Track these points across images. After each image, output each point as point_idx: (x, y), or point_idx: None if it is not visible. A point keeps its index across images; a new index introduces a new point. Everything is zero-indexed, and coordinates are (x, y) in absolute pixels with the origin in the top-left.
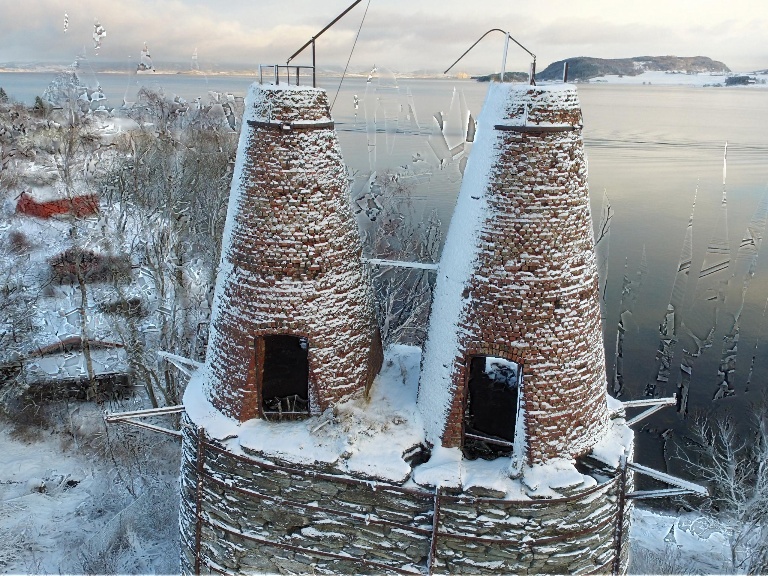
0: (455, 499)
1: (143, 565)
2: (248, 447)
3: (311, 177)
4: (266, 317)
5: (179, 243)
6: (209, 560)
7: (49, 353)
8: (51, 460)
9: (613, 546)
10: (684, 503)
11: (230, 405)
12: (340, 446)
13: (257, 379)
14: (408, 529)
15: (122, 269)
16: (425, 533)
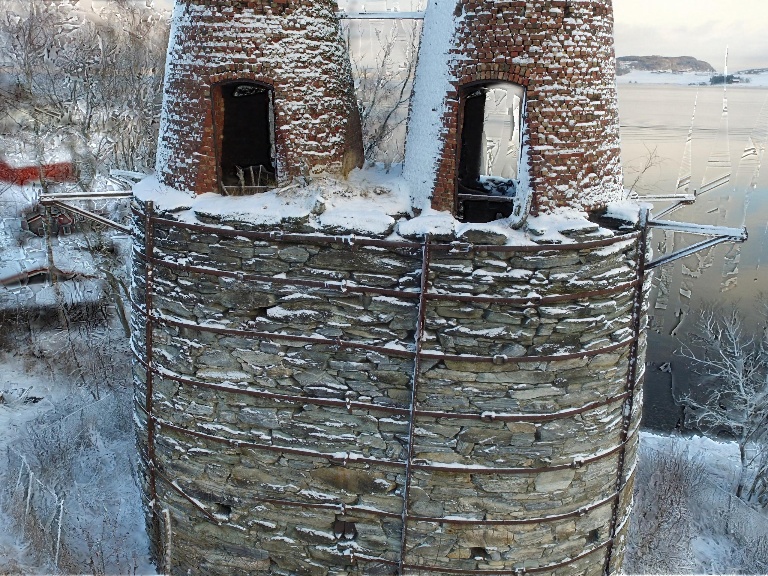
0: (447, 248)
1: (106, 461)
2: (203, 211)
3: None
4: (223, 58)
5: (151, 151)
6: (162, 368)
7: (8, 256)
8: (13, 379)
9: (631, 326)
10: (689, 402)
11: (183, 175)
12: (311, 200)
13: (215, 142)
14: (392, 295)
15: (85, 159)
16: (412, 300)
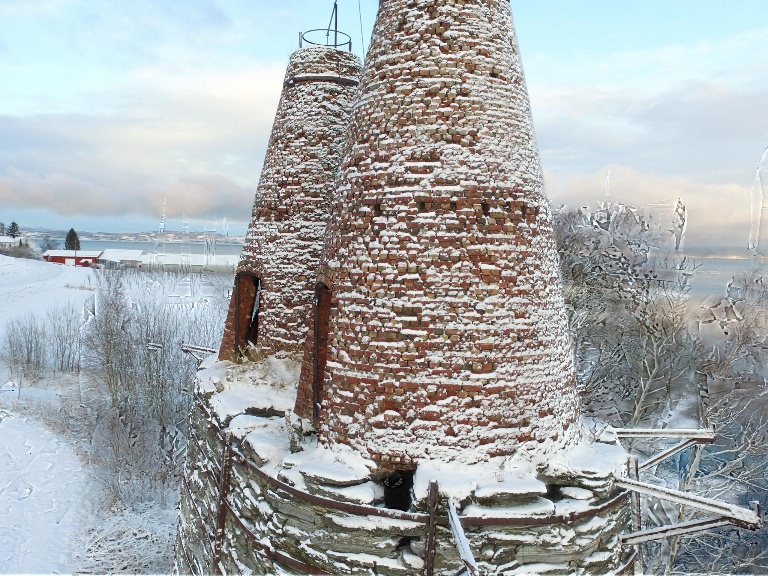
0: None
1: None
2: None
3: (299, 123)
4: None
5: None
6: None
7: None
8: None
9: None
10: None
11: None
12: None
13: (237, 320)
14: None
15: None
16: None
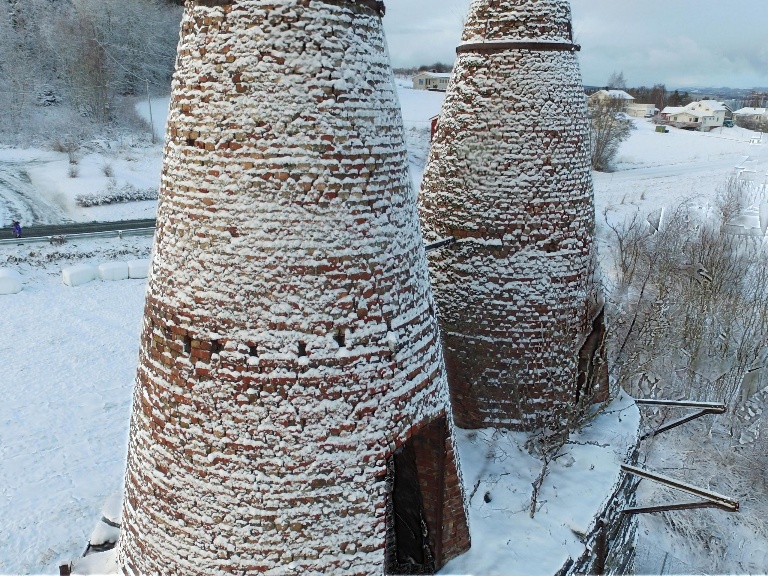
0: None
1: None
2: None
3: None
4: None
5: None
6: None
7: None
8: None
9: None
10: None
11: None
12: None
13: None
14: None
15: None
16: None
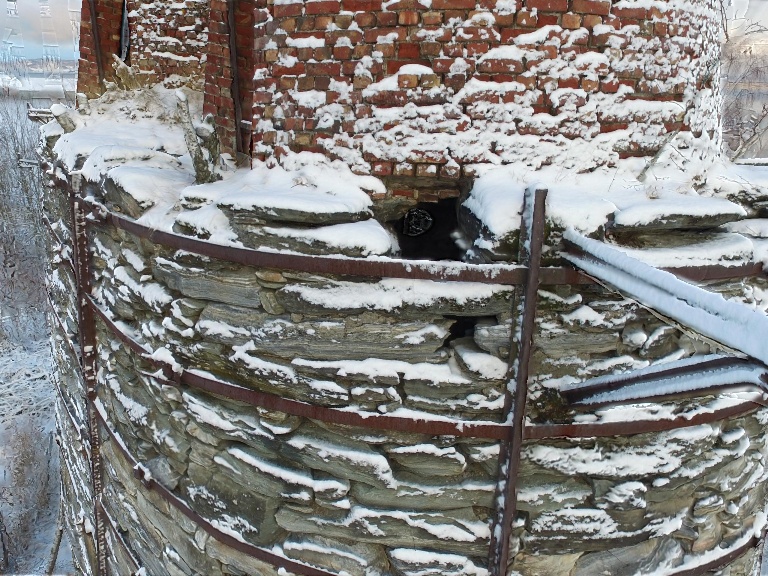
0: None
1: None
2: None
3: None
4: None
5: None
6: None
7: None
8: None
9: (487, 558)
10: None
11: None
12: None
13: (96, 42)
14: None
15: None
16: None
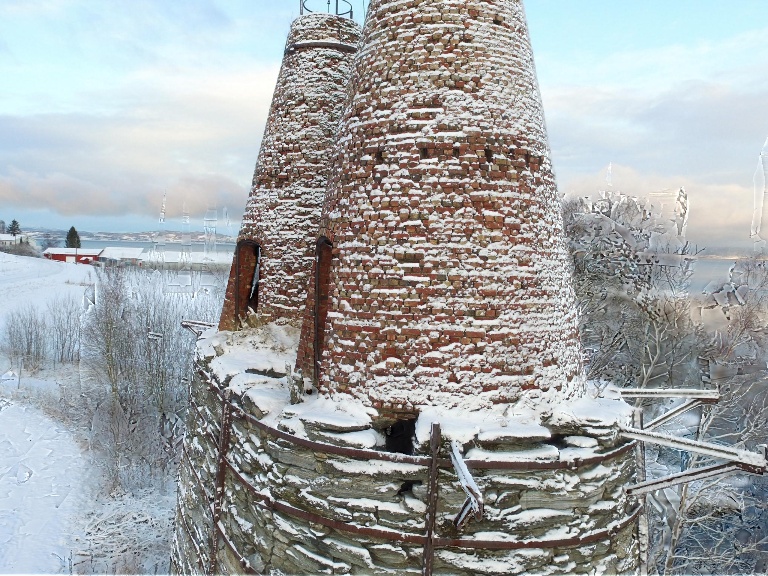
0: None
1: None
2: None
3: (299, 90)
4: None
5: None
6: None
7: None
8: None
9: None
10: None
11: None
12: None
13: (237, 290)
14: None
15: None
16: None
